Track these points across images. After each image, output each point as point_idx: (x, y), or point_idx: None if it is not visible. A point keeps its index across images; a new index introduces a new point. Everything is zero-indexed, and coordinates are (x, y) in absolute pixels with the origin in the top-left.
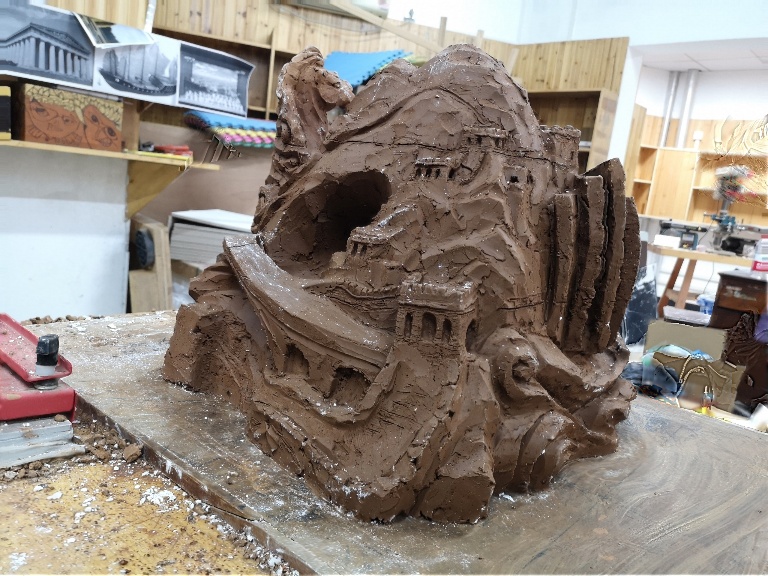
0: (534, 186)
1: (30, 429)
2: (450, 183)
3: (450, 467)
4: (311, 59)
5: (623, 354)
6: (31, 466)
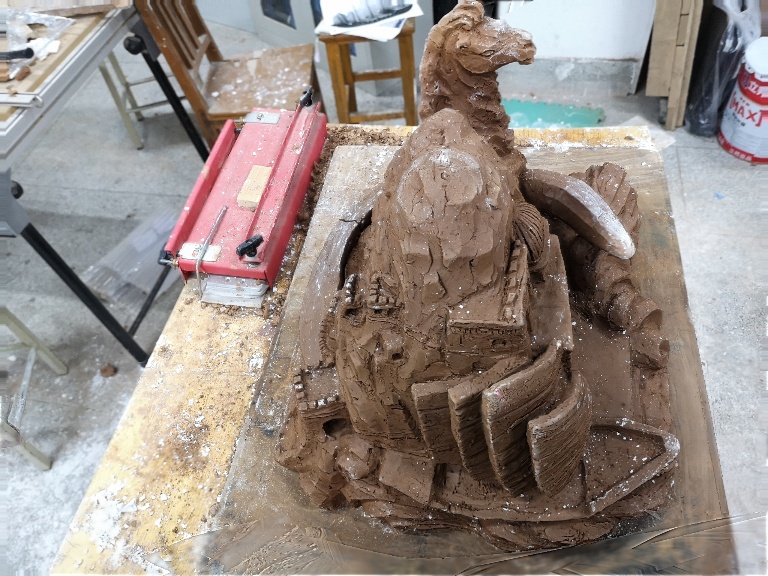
0: (406, 363)
1: (240, 286)
2: (343, 320)
3: (302, 477)
4: (455, 24)
5: (588, 509)
6: (232, 308)
